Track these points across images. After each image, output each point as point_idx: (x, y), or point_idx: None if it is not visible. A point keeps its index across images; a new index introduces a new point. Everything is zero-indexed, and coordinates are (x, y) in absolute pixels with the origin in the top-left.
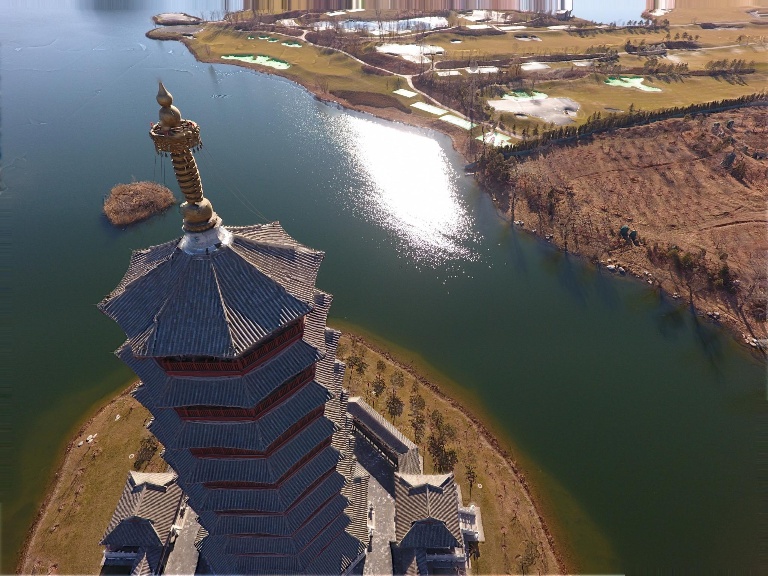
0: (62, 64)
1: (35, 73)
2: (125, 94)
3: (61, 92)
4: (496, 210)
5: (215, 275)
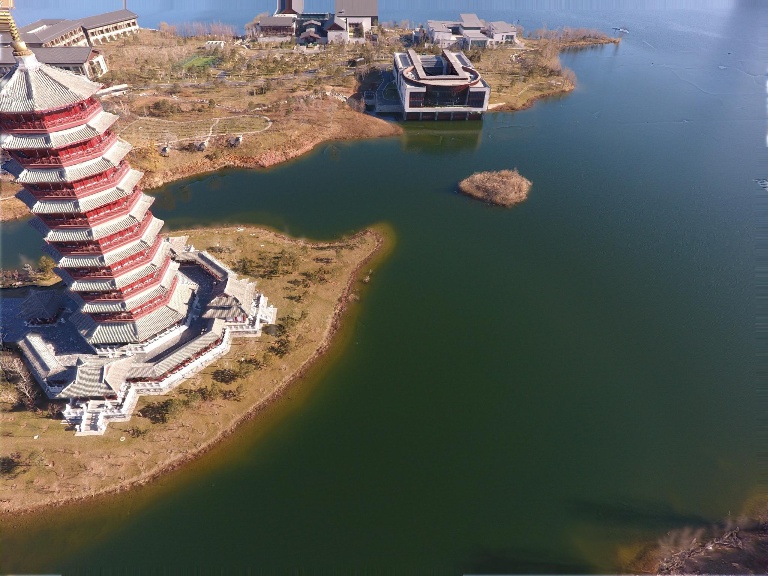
0: (727, 92)
1: (688, 88)
2: (696, 133)
3: (664, 107)
4: (666, 544)
5: (6, 74)
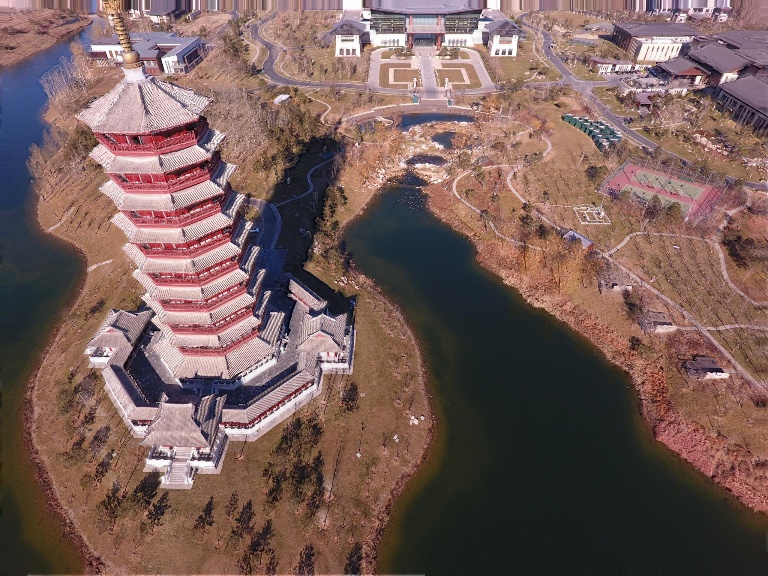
0: None
1: None
2: None
3: None
4: None
5: None
